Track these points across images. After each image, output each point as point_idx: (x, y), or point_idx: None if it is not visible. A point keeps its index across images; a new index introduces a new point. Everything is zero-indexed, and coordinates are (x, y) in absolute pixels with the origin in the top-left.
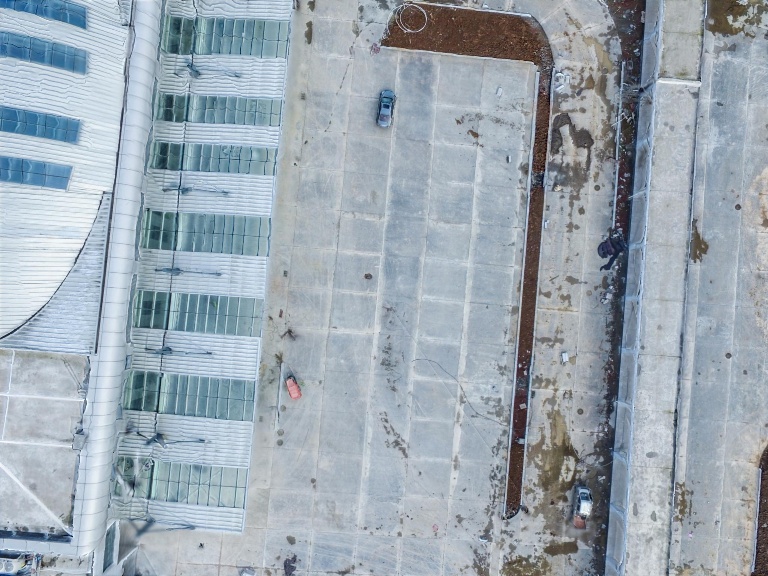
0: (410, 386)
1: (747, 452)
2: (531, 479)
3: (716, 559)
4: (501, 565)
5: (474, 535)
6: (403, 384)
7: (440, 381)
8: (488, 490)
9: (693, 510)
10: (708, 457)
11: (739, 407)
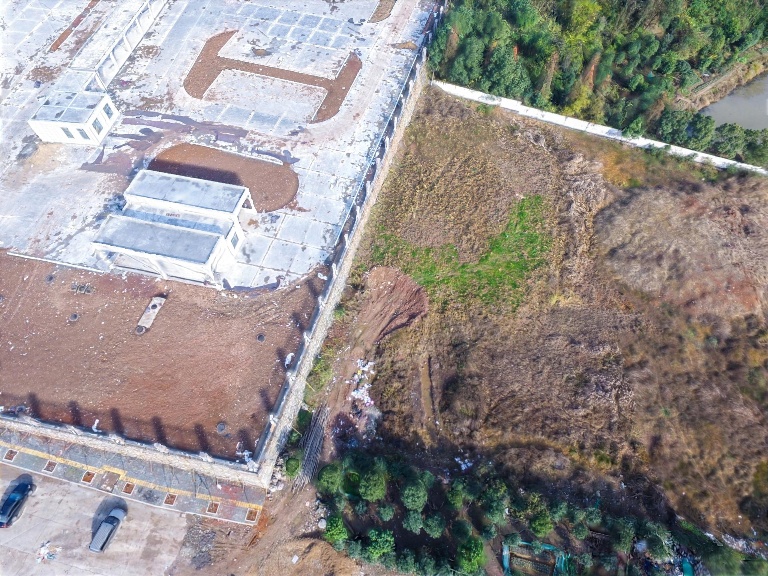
0: (24, 10)
1: (201, 37)
2: (71, 41)
3: (166, 73)
4: (32, 69)
5: (23, 58)
6: (20, 9)
7: (41, 9)
8: (43, 43)
9: (160, 55)
10: (178, 38)
11: (203, 23)
